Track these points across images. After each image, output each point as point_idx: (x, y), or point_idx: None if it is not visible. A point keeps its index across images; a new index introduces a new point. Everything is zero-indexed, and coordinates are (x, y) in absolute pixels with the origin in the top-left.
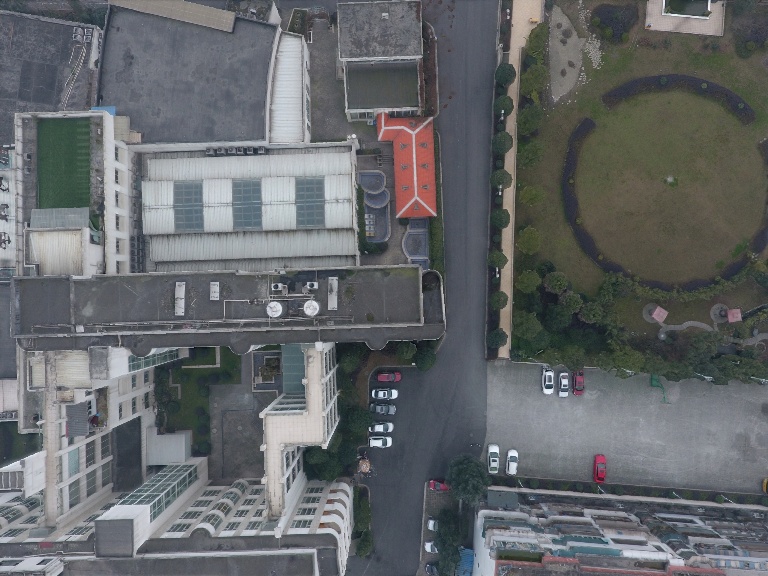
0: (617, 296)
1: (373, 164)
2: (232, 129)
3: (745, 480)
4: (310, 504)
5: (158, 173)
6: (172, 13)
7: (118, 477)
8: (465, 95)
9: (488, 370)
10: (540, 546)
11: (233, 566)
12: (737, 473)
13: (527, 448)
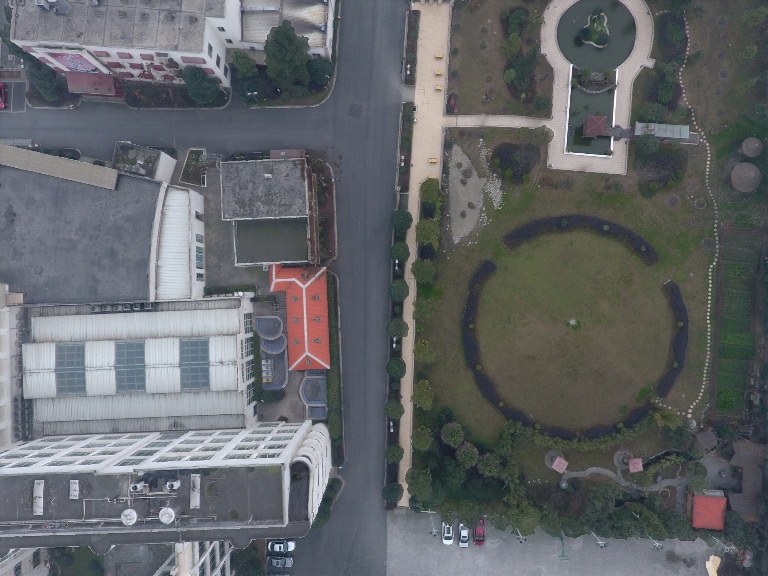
0: (515, 448)
1: (270, 309)
2: (116, 288)
3: None
4: None
5: (42, 331)
6: (53, 171)
7: None
8: (364, 237)
9: (388, 519)
10: None
11: None
12: None
13: None
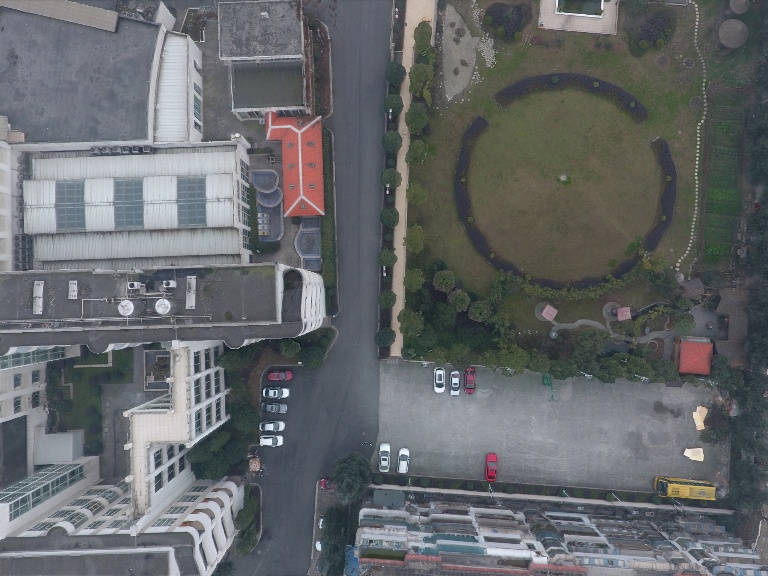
0: (506, 294)
1: (266, 163)
2: (116, 128)
3: (637, 478)
4: (184, 503)
5: (43, 172)
6: (55, 13)
7: (4, 476)
8: (359, 94)
9: (380, 369)
10: (408, 544)
11: (90, 565)
12: (629, 471)
13: (419, 447)
